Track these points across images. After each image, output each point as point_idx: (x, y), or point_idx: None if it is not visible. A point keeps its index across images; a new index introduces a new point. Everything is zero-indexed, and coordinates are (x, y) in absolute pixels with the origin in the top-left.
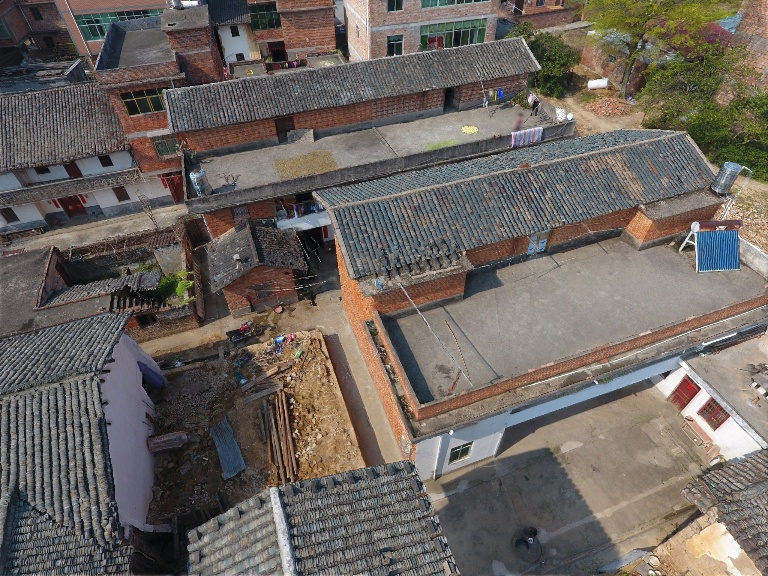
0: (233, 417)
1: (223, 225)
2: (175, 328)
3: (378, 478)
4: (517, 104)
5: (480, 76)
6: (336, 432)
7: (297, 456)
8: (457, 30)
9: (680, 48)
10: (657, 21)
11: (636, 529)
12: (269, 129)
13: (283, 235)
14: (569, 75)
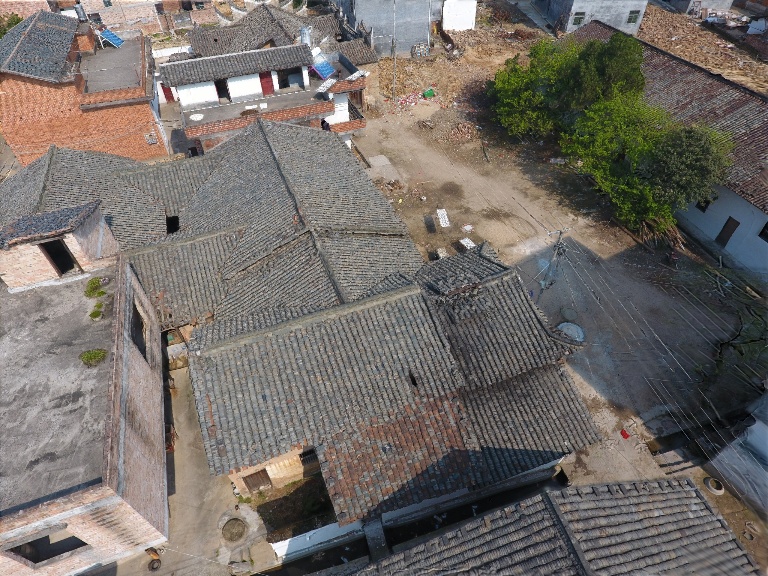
0: None
1: None
2: None
3: None
4: None
5: None
6: None
7: None
8: None
9: None
10: None
11: None
12: None
13: None
14: None
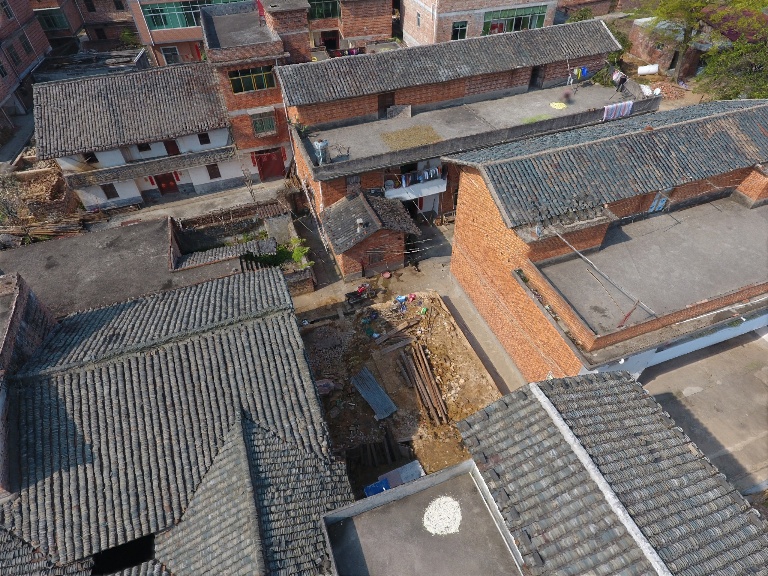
0: (372, 367)
1: (336, 194)
2: (293, 291)
3: (606, 382)
4: (597, 82)
5: (566, 55)
6: (476, 378)
7: (444, 399)
8: (518, 17)
9: (730, 34)
10: (716, 6)
11: (767, 461)
12: (372, 104)
13: (392, 204)
14: (618, 62)
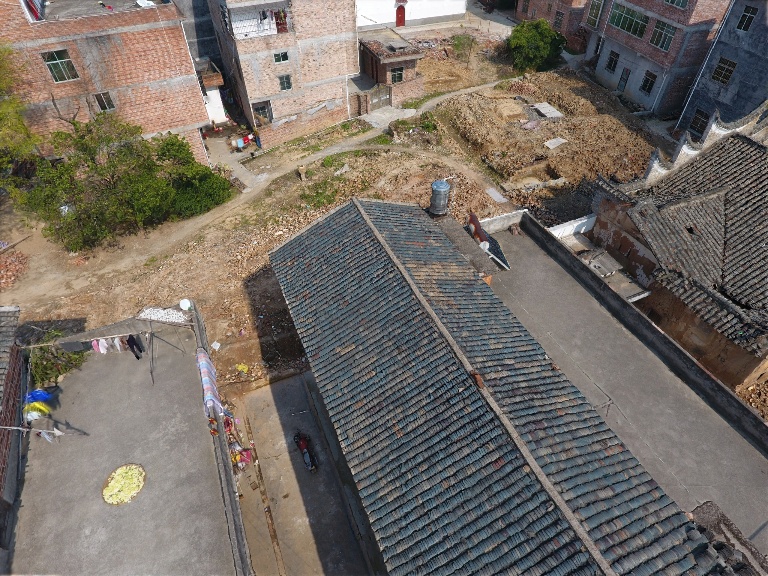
0: None
1: None
2: None
3: None
4: (58, 377)
5: None
6: None
7: None
8: None
9: None
10: None
11: None
12: None
13: None
14: None
